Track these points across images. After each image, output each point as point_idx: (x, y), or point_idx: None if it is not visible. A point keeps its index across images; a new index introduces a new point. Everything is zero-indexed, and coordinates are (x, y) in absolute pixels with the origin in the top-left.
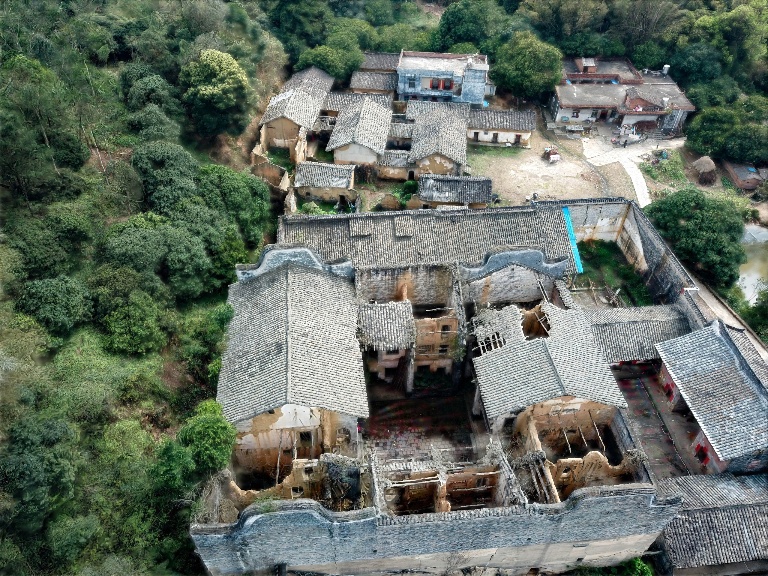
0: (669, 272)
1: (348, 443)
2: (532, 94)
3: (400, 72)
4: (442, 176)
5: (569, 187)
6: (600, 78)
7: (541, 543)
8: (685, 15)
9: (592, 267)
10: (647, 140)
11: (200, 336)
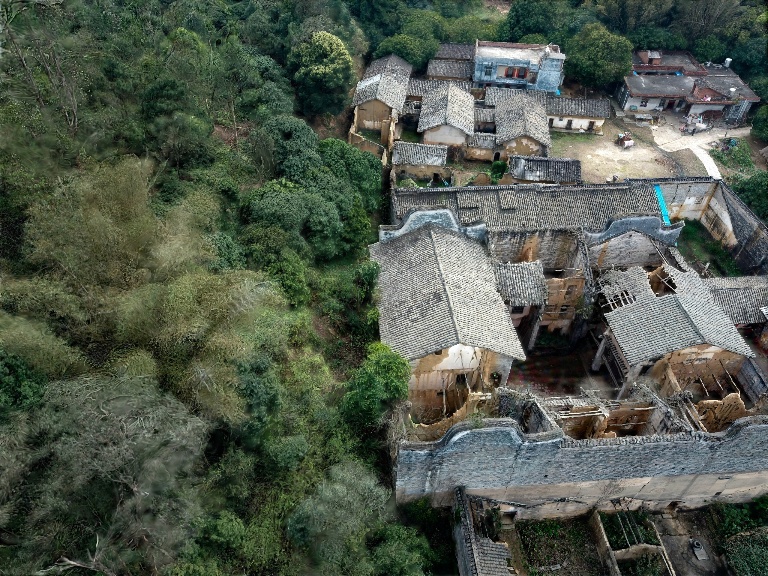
0: (763, 245)
1: (496, 387)
2: (602, 84)
3: (478, 60)
4: (530, 157)
5: (645, 171)
6: (665, 70)
7: (692, 473)
8: (747, 11)
9: (680, 243)
10: (713, 129)
11: (334, 294)
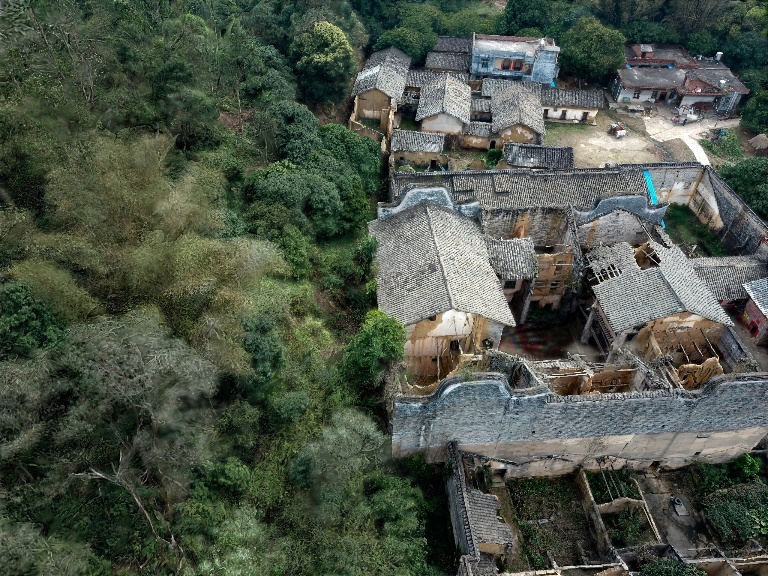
0: (747, 227)
1: None
2: (596, 76)
3: (475, 52)
4: (525, 144)
5: (637, 159)
6: (657, 63)
7: (671, 432)
8: (737, 6)
9: (669, 226)
10: (704, 120)
11: (335, 270)
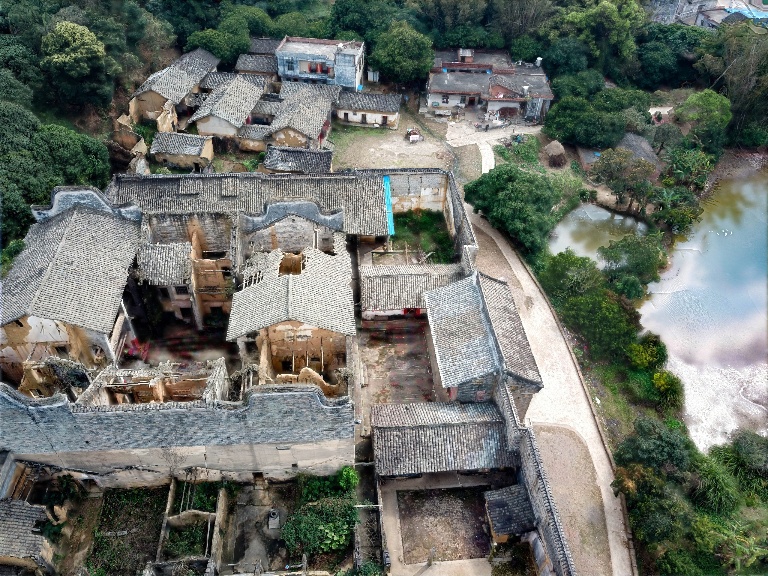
0: (464, 234)
1: (106, 361)
2: (406, 80)
3: (278, 55)
4: (292, 148)
5: (421, 164)
6: (476, 68)
7: (243, 443)
8: (558, 11)
9: (413, 232)
10: (510, 126)
11: None
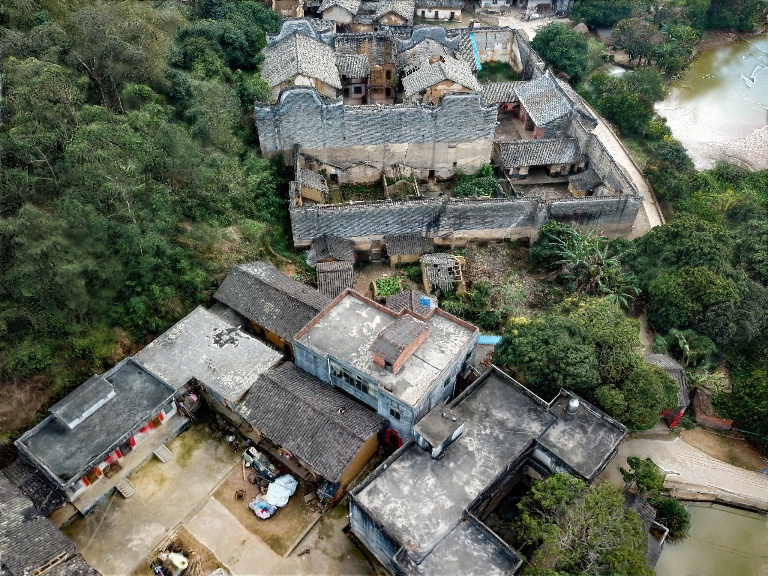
0: (532, 62)
1: None
2: None
3: None
4: None
5: None
6: None
7: (430, 141)
8: None
9: (491, 74)
10: (545, 18)
11: None
